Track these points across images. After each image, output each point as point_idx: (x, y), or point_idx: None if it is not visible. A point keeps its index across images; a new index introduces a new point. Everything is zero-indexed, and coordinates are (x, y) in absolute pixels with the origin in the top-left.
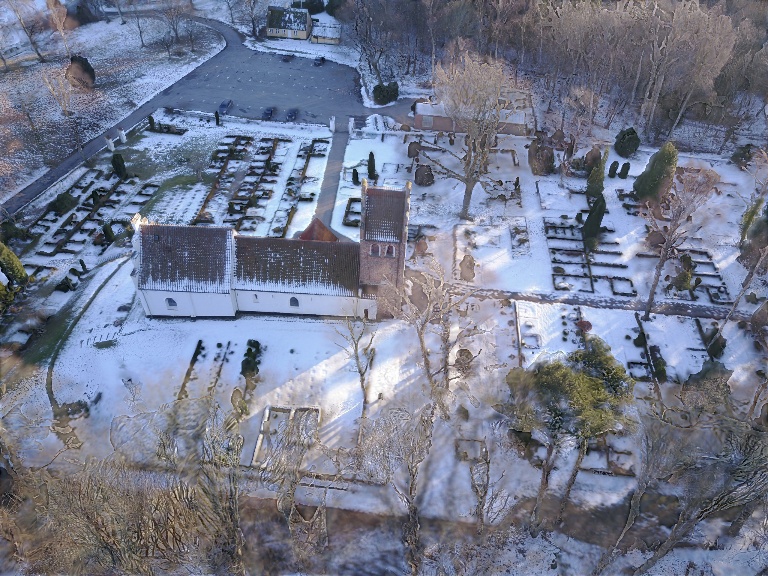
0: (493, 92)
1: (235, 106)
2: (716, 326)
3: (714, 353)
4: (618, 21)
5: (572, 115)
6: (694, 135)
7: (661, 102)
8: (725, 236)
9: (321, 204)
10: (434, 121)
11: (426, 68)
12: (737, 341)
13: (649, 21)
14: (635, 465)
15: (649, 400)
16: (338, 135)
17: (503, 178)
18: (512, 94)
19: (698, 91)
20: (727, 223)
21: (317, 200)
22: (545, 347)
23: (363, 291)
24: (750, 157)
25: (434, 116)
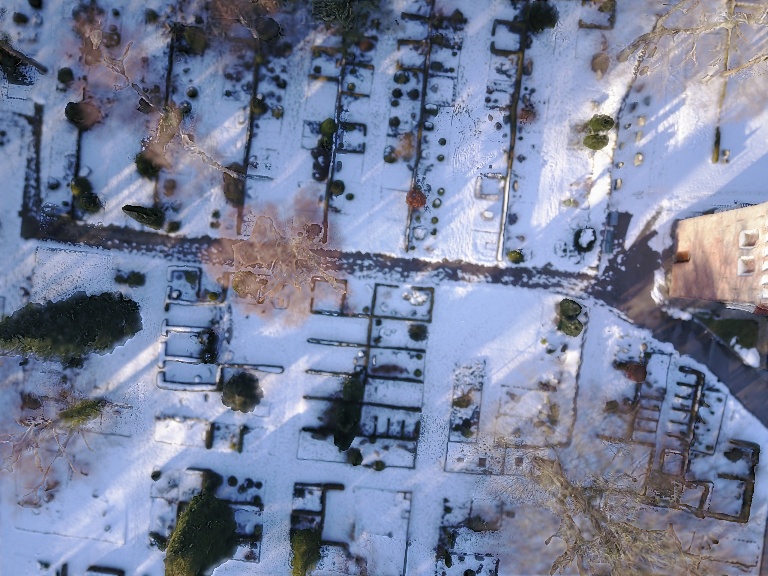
0: None
1: None
2: (215, 221)
3: None
4: None
5: None
6: None
7: None
8: (111, 434)
9: None
10: None
11: None
12: (195, 197)
13: None
14: None
15: (354, 93)
16: None
17: None
18: None
19: None
20: (90, 474)
21: None
22: (472, 177)
23: None
24: None
25: None
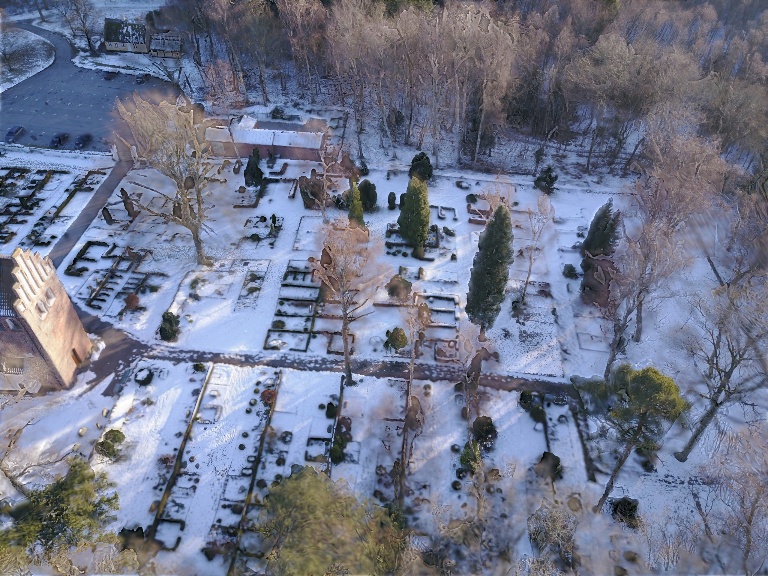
0: (174, 133)
1: (28, 133)
2: (428, 390)
3: (410, 424)
4: (380, 40)
5: (379, 136)
6: (520, 153)
7: (471, 121)
8: None
9: (57, 249)
10: (225, 147)
11: (258, 83)
12: (446, 407)
13: (459, 33)
14: (261, 571)
15: None
16: (121, 164)
17: (270, 213)
18: (329, 112)
19: (490, 111)
20: None
21: (55, 244)
22: (222, 421)
23: (8, 365)
24: (552, 181)
25: (223, 142)
